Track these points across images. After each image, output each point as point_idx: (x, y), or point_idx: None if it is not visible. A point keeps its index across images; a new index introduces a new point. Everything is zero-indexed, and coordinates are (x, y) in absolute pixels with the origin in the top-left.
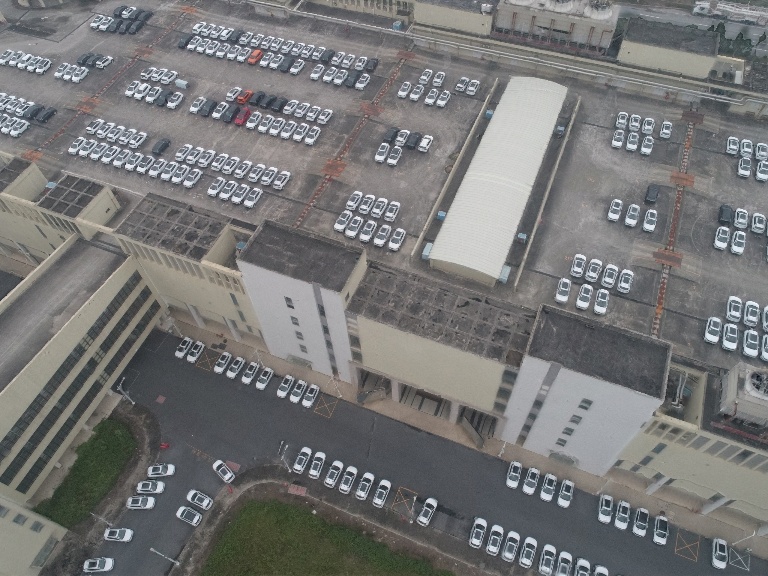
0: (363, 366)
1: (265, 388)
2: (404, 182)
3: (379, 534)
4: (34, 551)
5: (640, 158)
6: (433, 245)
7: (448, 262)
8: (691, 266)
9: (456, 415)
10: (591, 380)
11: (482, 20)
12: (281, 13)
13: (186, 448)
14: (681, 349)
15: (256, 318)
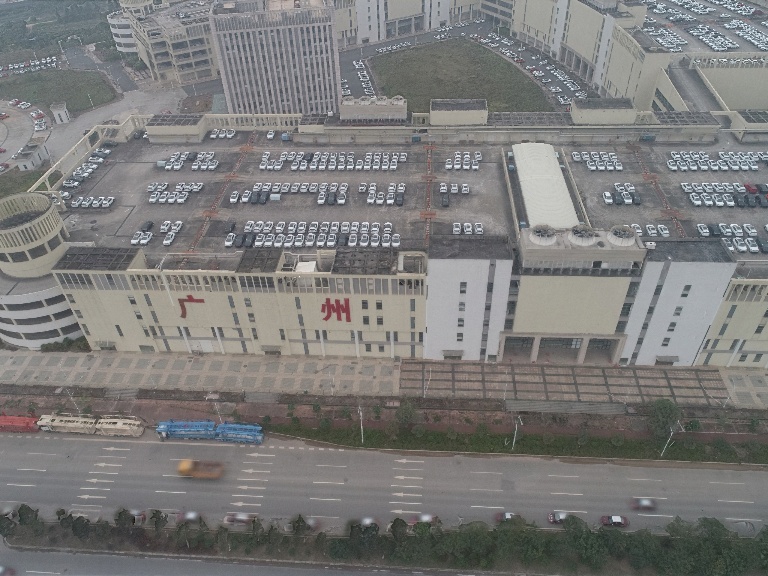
0: None
1: None
2: (600, 181)
3: None
4: None
5: None
6: None
7: None
8: None
9: None
10: None
11: None
12: None
13: None
14: (417, 151)
15: None
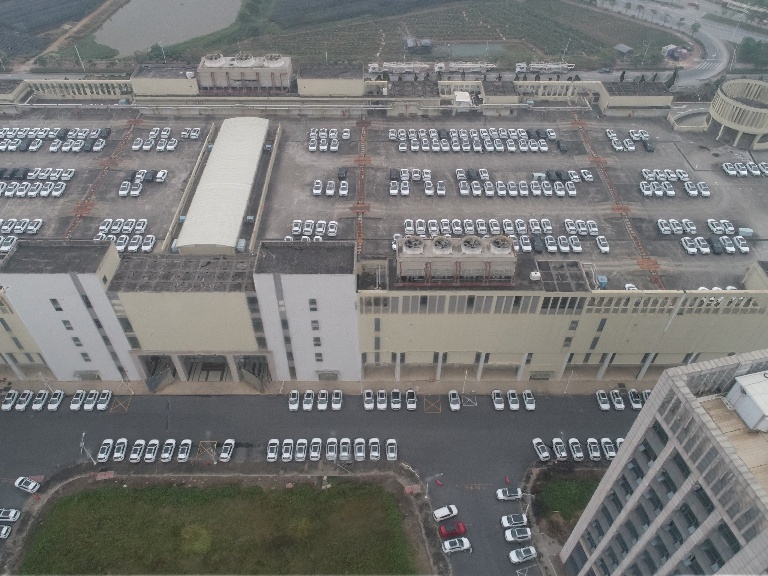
0: (143, 351)
1: (58, 408)
2: (148, 206)
3: (188, 481)
4: None
5: (331, 154)
6: (178, 238)
7: (192, 246)
8: (377, 210)
9: (236, 370)
10: (303, 277)
11: (189, 83)
12: (12, 110)
13: None
14: None
15: (32, 339)
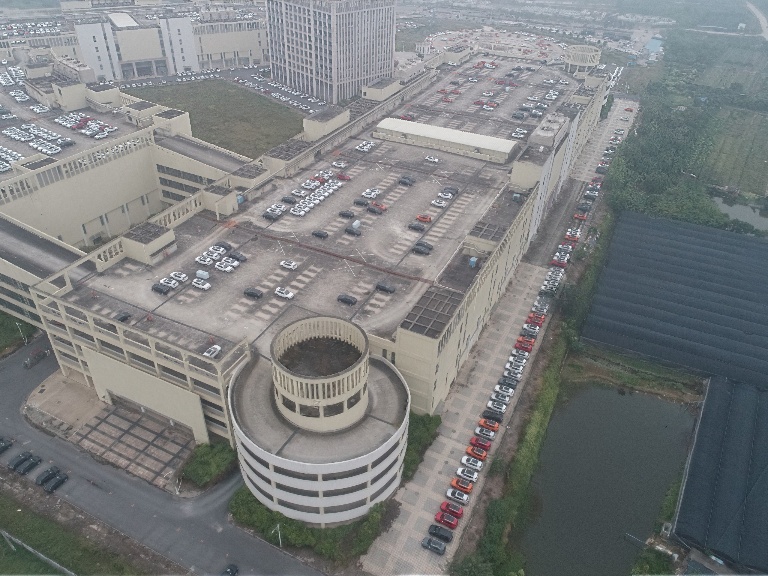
0: (123, 61)
1: None
2: None
3: None
4: None
5: None
6: None
7: None
8: None
9: (155, 69)
10: (175, 19)
11: (87, 2)
12: (3, 21)
13: None
14: None
15: (83, 58)
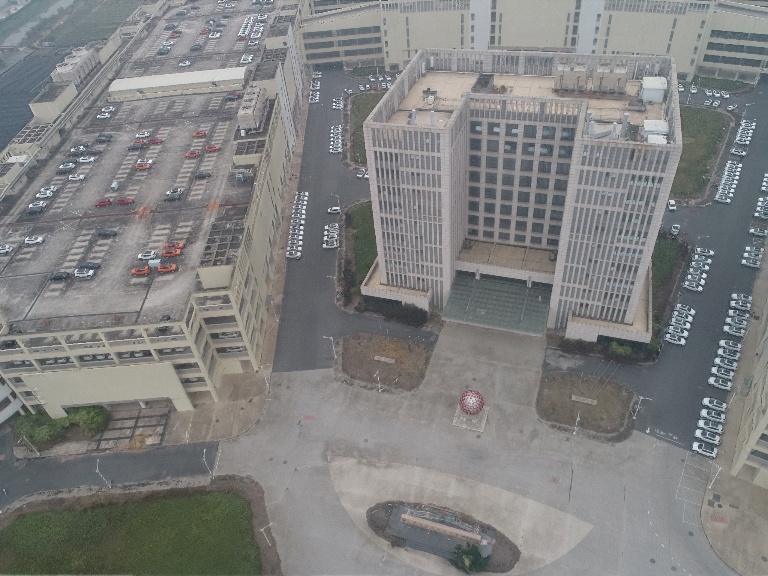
0: None
1: None
2: None
3: (721, 143)
4: (682, 70)
5: None
6: None
7: None
8: None
9: None
10: None
11: None
12: None
13: (739, 100)
14: None
15: None
